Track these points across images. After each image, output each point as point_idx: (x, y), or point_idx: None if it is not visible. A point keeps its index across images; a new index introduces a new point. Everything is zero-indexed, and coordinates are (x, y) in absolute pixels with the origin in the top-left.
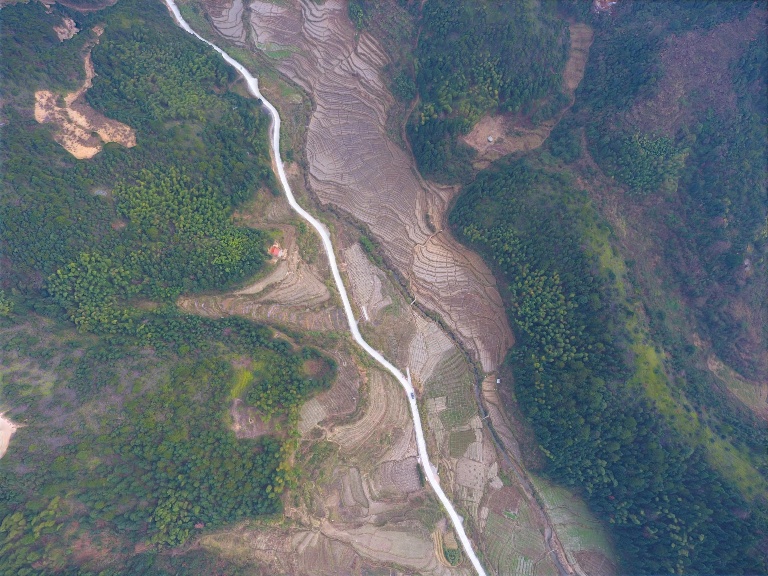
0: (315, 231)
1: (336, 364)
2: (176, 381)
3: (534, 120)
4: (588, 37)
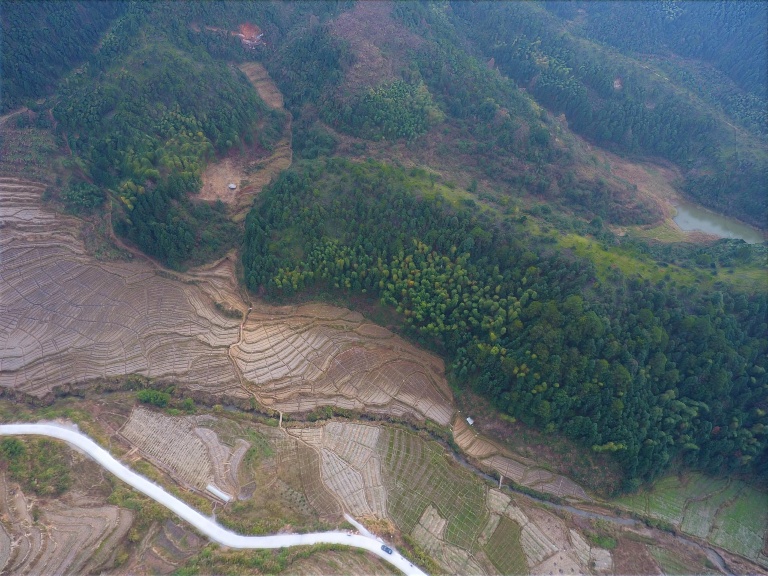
0: (41, 438)
1: None
2: None
3: (265, 145)
4: (261, 69)
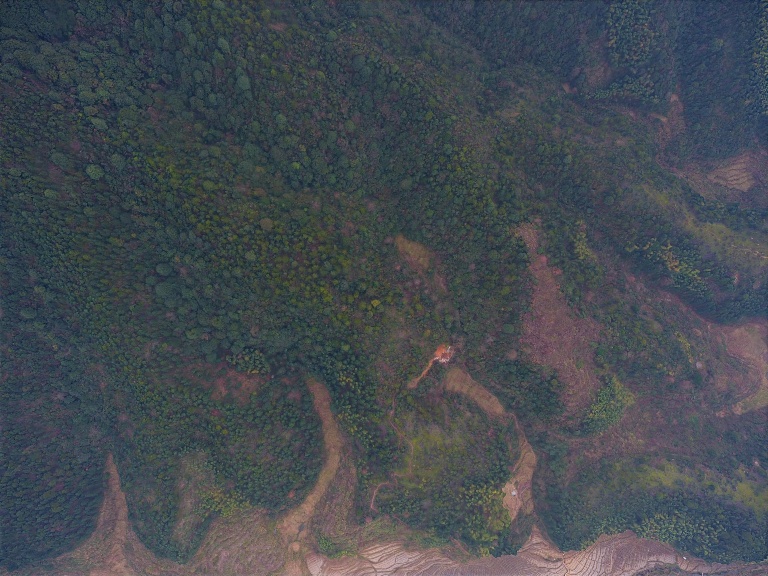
0: None
1: None
2: None
3: (518, 458)
4: (463, 376)
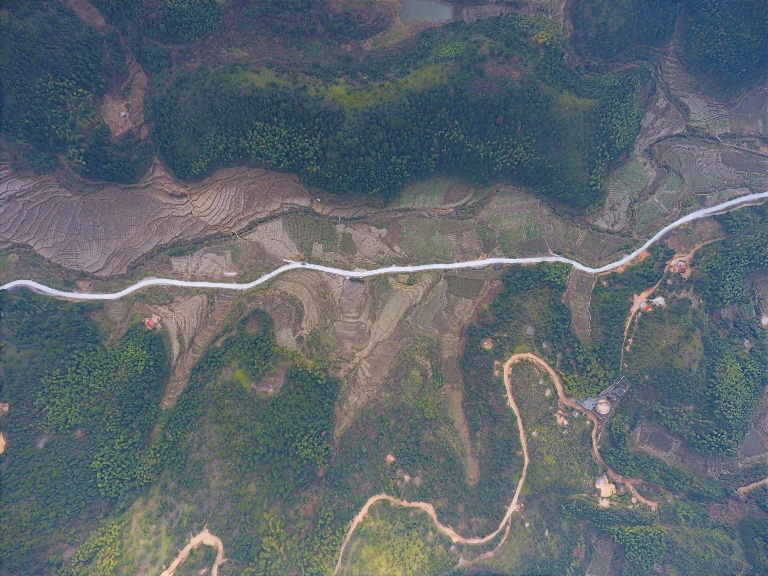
0: (147, 287)
1: (257, 309)
2: (219, 421)
3: (120, 71)
4: None
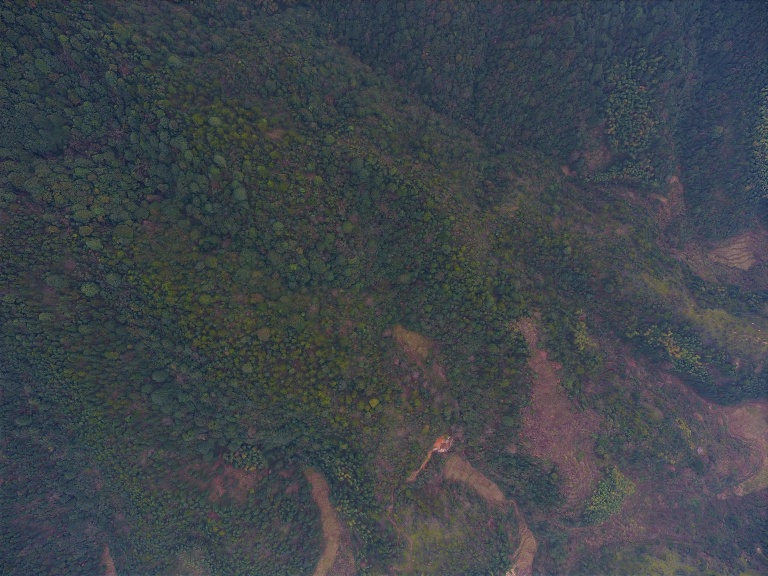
0: None
1: None
2: None
3: (518, 545)
4: (462, 464)
